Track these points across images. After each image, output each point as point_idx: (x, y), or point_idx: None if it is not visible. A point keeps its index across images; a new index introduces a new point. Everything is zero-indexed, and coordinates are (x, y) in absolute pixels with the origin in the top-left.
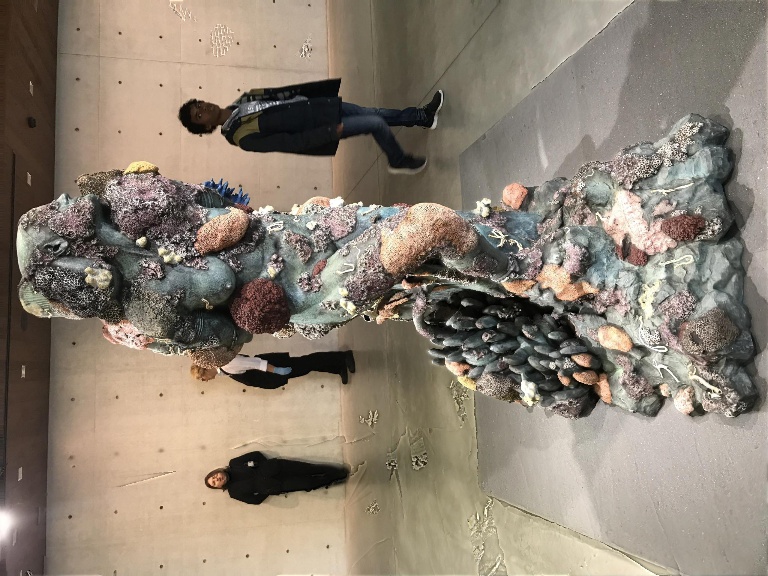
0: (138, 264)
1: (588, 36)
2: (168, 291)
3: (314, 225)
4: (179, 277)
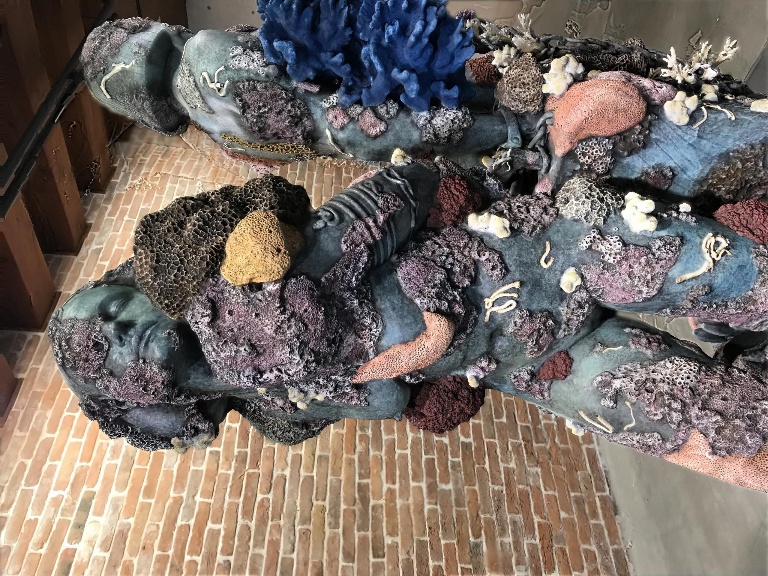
0: (255, 393)
1: None
2: (302, 419)
3: (575, 285)
4: (320, 411)
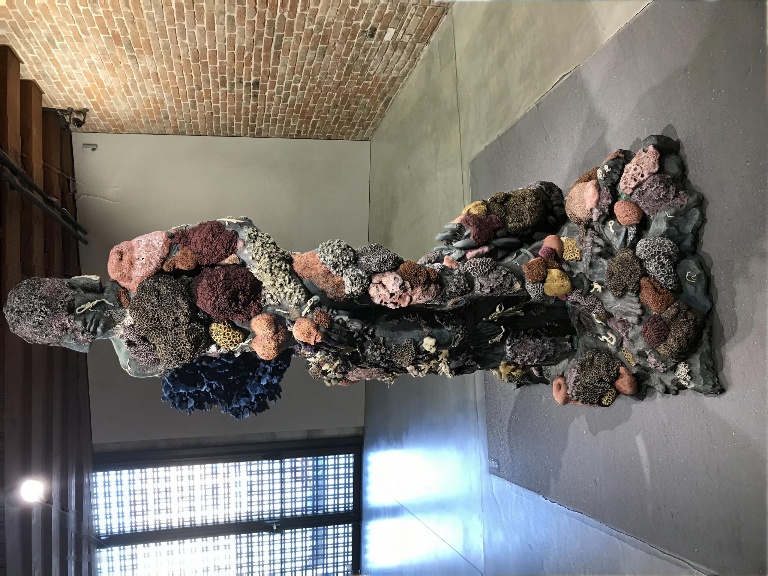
0: None
1: (667, 573)
2: None
3: None
4: None
